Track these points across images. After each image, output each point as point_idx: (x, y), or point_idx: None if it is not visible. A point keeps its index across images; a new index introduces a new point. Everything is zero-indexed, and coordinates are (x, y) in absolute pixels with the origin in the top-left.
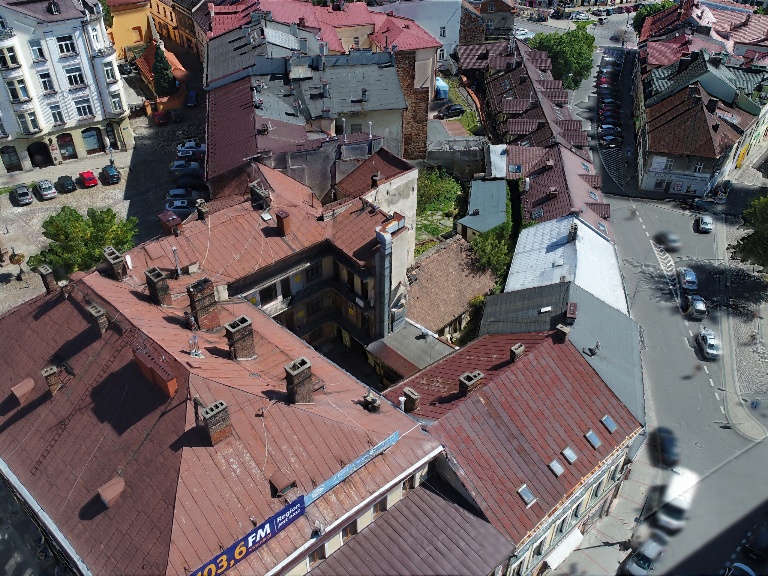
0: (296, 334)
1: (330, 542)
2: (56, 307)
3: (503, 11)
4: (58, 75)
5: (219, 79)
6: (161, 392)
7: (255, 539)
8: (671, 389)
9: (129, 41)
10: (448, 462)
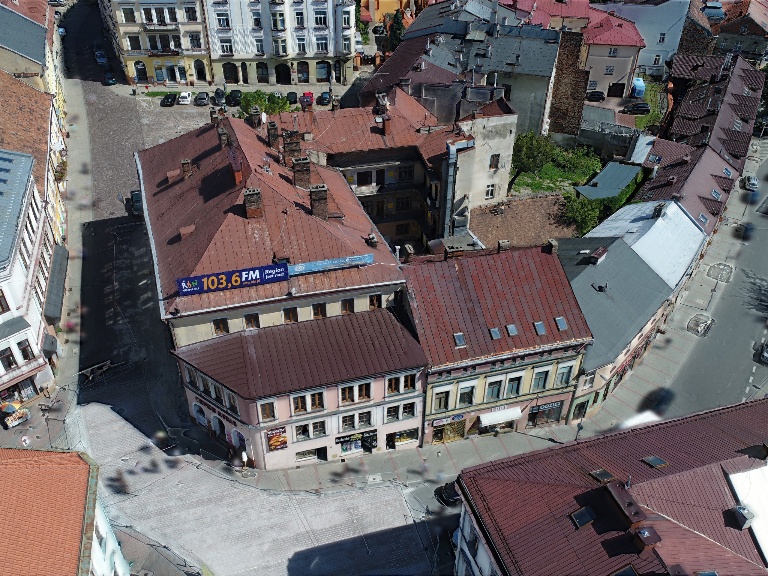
0: (383, 220)
1: (302, 309)
2: (209, 131)
3: (756, 35)
4: (309, 15)
5: (413, 31)
6: (234, 182)
7: (248, 277)
8: (704, 371)
9: (390, 9)
10: (407, 294)
